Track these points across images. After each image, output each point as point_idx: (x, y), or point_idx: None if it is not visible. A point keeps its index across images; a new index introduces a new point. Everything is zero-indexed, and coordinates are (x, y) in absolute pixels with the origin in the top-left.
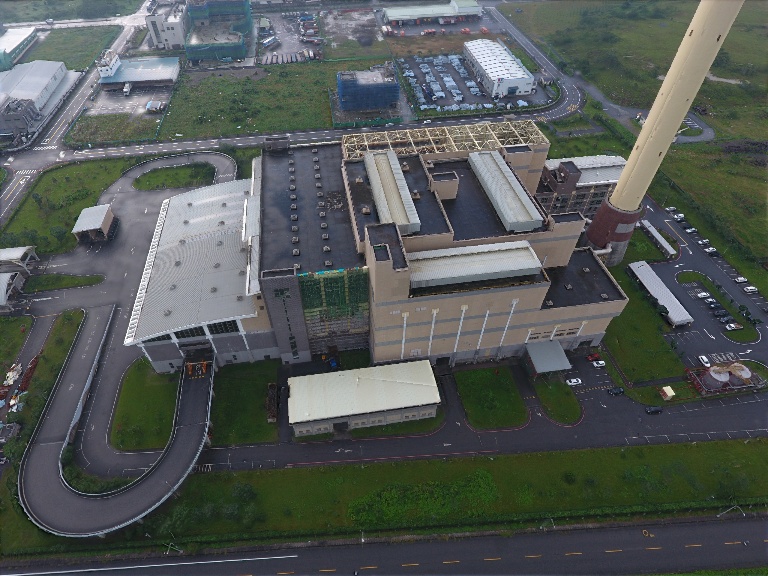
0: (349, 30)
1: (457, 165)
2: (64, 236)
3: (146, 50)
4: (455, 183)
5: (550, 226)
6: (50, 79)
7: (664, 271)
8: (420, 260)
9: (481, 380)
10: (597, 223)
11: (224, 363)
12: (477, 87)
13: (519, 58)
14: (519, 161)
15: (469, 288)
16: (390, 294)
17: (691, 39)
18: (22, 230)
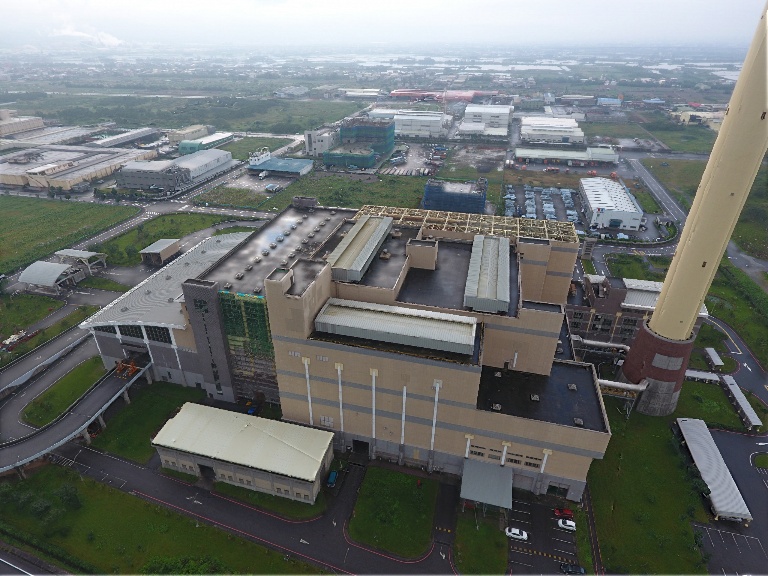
0: (474, 160)
1: (461, 246)
2: (134, 255)
3: (298, 155)
4: (432, 251)
5: (518, 312)
6: (213, 160)
7: (735, 444)
8: (343, 307)
9: (394, 485)
10: (631, 350)
11: (160, 378)
12: (577, 216)
13: (642, 200)
14: (534, 254)
15: (380, 348)
16: (285, 326)
17: (728, 118)
18: (108, 243)
